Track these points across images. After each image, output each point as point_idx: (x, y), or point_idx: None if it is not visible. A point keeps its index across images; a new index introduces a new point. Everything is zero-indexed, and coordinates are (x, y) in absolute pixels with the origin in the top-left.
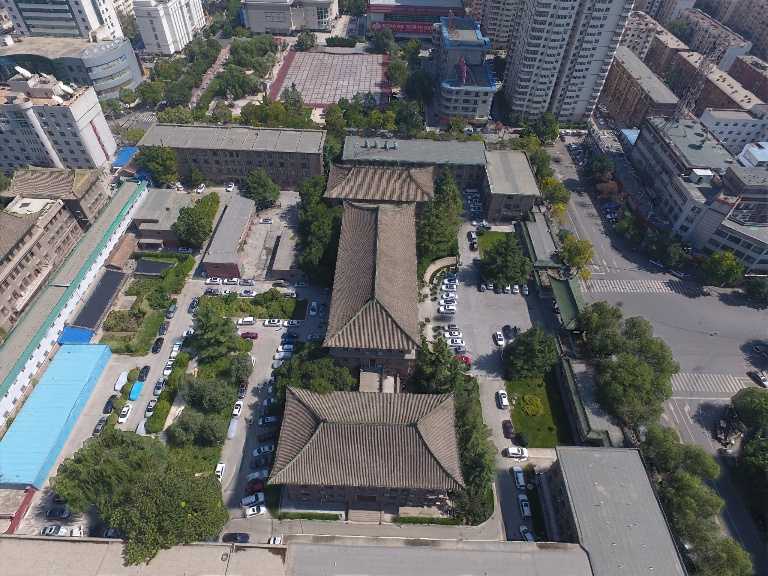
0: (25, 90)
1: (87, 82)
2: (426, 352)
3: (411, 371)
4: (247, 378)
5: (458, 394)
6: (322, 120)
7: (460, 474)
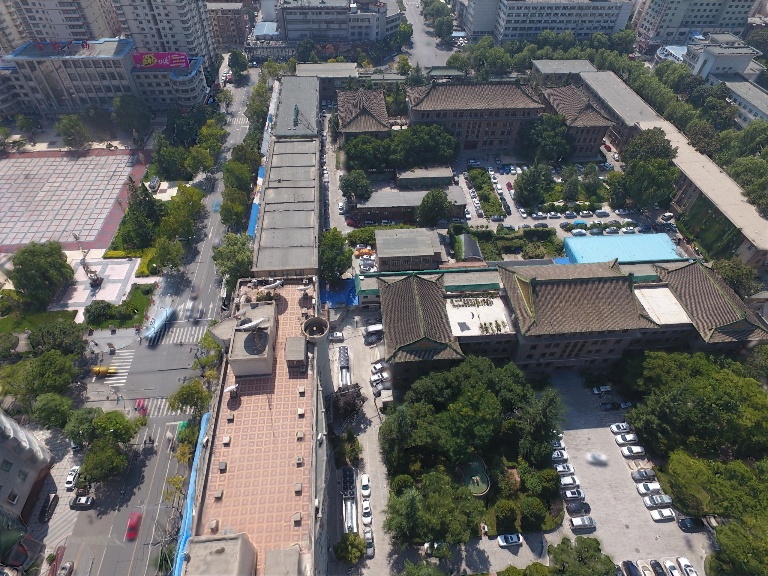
0: (271, 344)
1: (9, 465)
2: None
3: None
4: None
5: None
6: (170, 191)
7: None
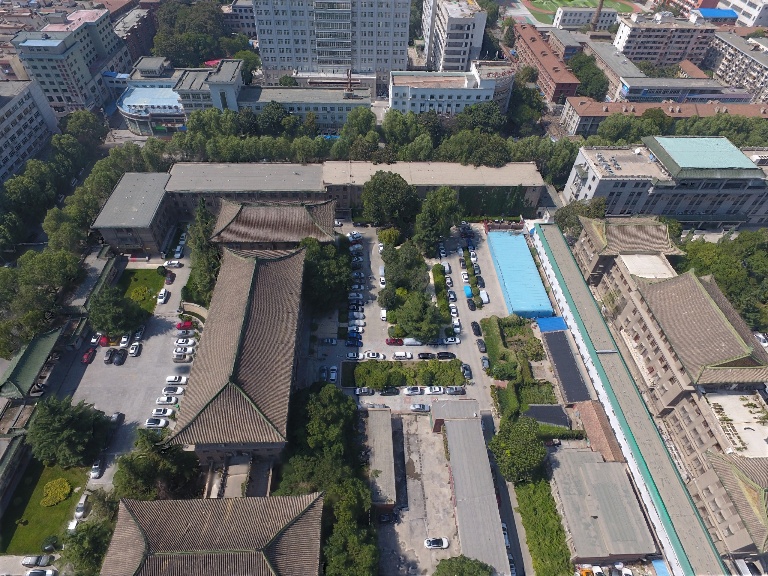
0: None
1: None
2: None
3: None
4: None
5: None
6: None
7: None
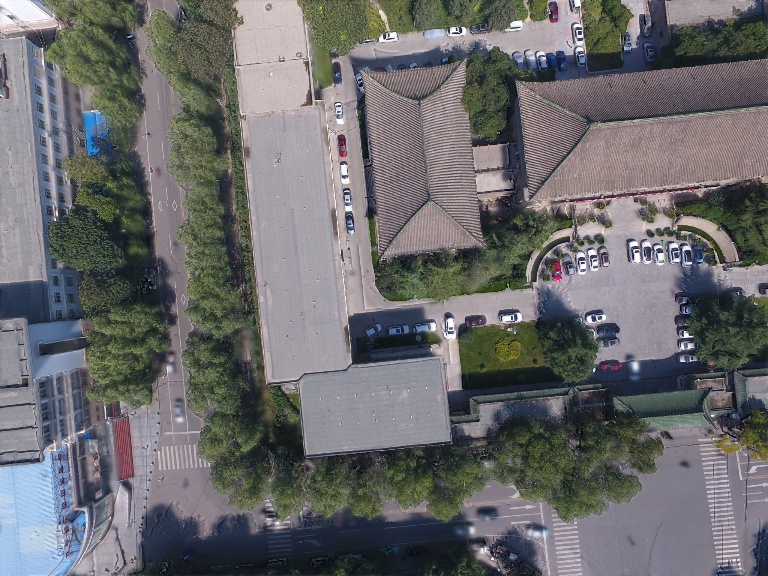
0: None
1: None
2: (544, 217)
3: (533, 212)
4: (492, 26)
5: (499, 260)
6: None
7: (395, 254)
